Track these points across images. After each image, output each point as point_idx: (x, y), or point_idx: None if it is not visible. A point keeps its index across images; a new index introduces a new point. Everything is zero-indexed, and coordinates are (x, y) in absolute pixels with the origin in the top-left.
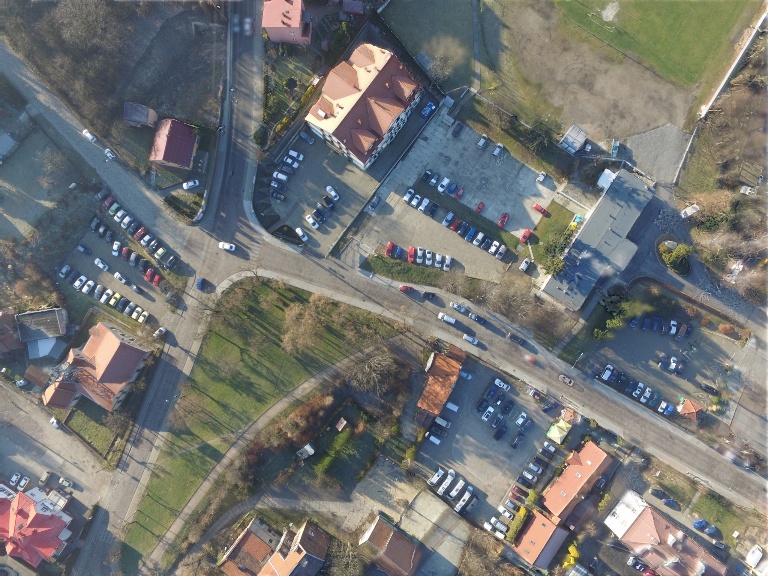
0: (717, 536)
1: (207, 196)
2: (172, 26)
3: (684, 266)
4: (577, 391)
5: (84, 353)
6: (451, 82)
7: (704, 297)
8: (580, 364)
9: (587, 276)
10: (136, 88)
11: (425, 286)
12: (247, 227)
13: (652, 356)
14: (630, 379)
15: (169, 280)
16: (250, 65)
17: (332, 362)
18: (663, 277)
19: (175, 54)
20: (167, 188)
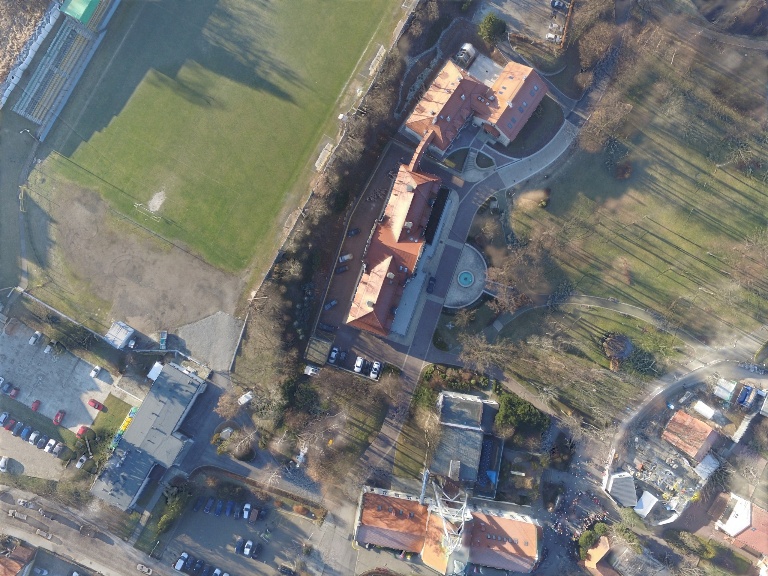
0: None
1: None
2: None
3: (244, 453)
4: None
5: None
6: None
7: (273, 480)
8: (157, 553)
9: (133, 476)
10: None
11: None
12: None
13: (229, 540)
14: (204, 567)
15: None
16: None
17: None
18: (227, 464)
19: None
20: None
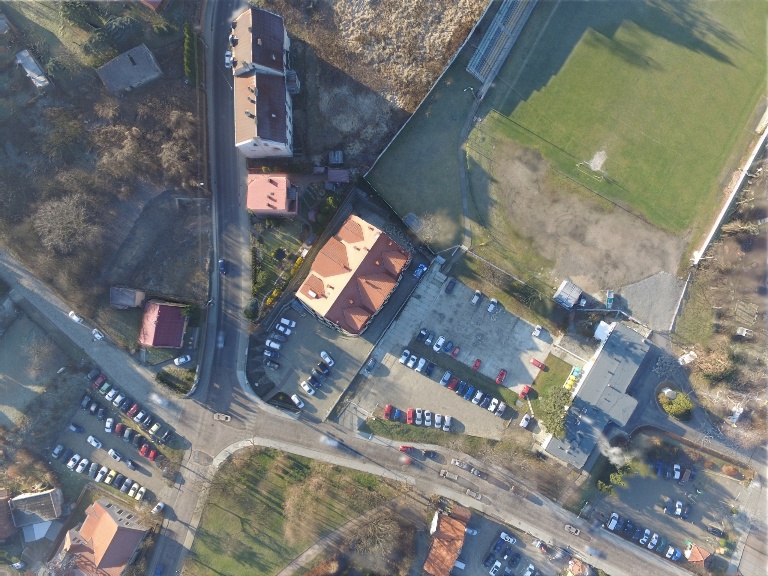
0: None
1: (199, 370)
2: (155, 205)
3: (685, 413)
4: (584, 540)
5: (81, 535)
6: (441, 241)
7: (706, 441)
8: (585, 513)
9: (588, 434)
10: (121, 268)
11: (425, 444)
12: (242, 397)
13: (657, 501)
14: (636, 527)
15: (165, 454)
16: (237, 236)
17: (335, 527)
18: (664, 424)
19: (160, 230)
20: (158, 364)
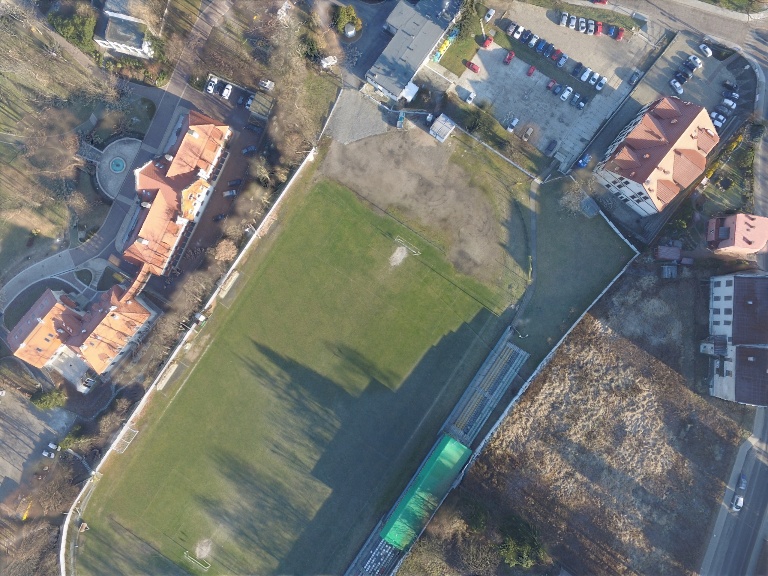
0: None
1: None
2: None
3: (336, 12)
4: None
5: None
6: (561, 189)
7: None
8: None
9: None
10: None
11: (581, 5)
12: (760, 58)
13: None
14: None
15: None
16: (765, 207)
17: None
18: (355, 4)
19: None
20: None
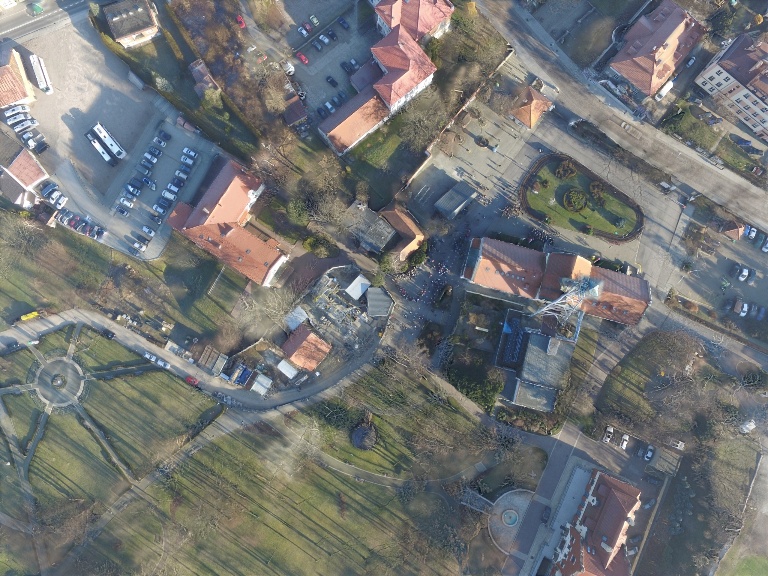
0: (695, 110)
1: None
2: None
3: (750, 371)
4: None
5: None
6: None
7: (719, 339)
8: None
9: None
10: None
11: None
12: None
13: (760, 282)
14: None
15: None
16: None
17: None
18: (766, 360)
19: None
20: None
